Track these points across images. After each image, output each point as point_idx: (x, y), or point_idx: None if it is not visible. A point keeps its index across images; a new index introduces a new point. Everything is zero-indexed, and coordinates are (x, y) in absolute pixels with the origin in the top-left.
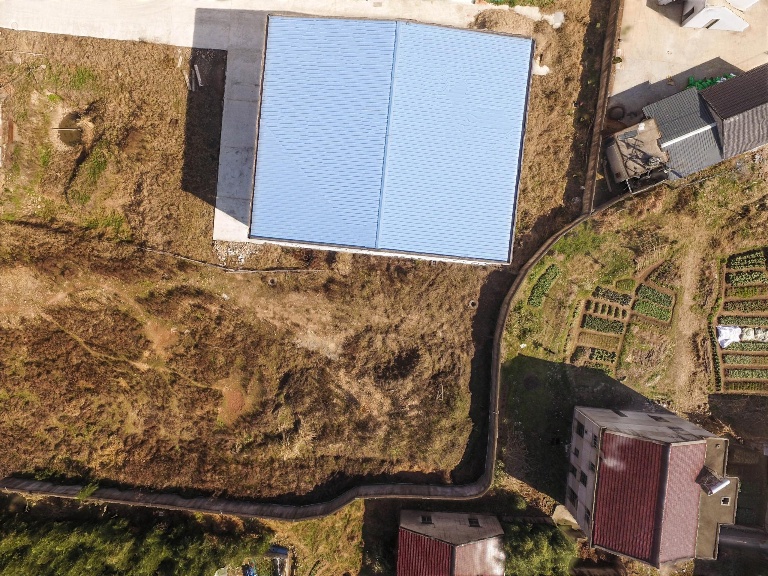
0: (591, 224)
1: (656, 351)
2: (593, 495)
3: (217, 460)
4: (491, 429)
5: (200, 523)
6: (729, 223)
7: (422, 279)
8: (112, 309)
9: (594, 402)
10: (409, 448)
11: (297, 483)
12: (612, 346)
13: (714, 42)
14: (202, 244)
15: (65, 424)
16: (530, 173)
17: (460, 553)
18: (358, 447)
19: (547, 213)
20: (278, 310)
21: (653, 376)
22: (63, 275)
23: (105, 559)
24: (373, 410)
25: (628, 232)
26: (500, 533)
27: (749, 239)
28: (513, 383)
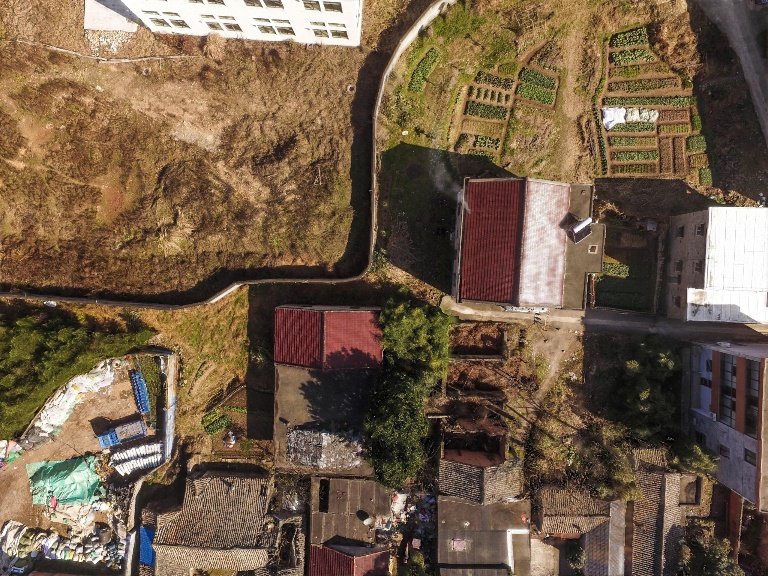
0: (469, 4)
1: (540, 136)
2: (459, 248)
3: (96, 256)
4: None
5: (82, 324)
6: None
7: (298, 63)
8: None
9: None
10: (289, 236)
11: (179, 280)
12: (496, 132)
13: None
14: (74, 35)
15: None
16: None
17: (330, 320)
18: (238, 238)
19: None
20: (153, 101)
21: (538, 161)
22: None
23: None
24: (250, 196)
25: (508, 12)
26: (377, 310)
27: (630, 14)
28: (396, 172)
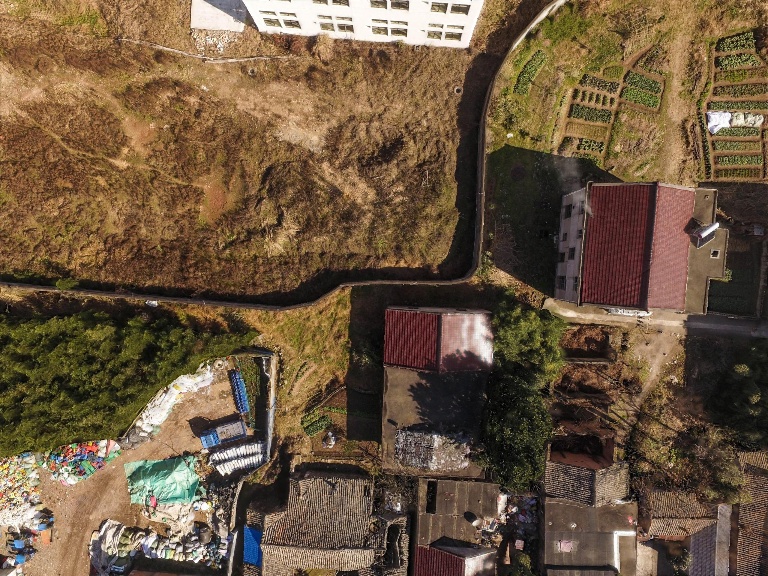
0: (577, 7)
1: (645, 139)
2: (580, 252)
3: (199, 256)
4: (478, 216)
5: (184, 324)
6: (718, 3)
7: (405, 65)
8: (89, 104)
9: None
10: (395, 238)
11: (282, 281)
12: (600, 136)
13: None
14: (179, 34)
15: (44, 225)
16: None
17: (446, 322)
18: (343, 240)
19: None
20: (259, 101)
21: (642, 165)
22: (38, 69)
23: (86, 350)
24: (357, 198)
25: (615, 15)
26: (488, 312)
27: (738, 19)
28: (500, 175)
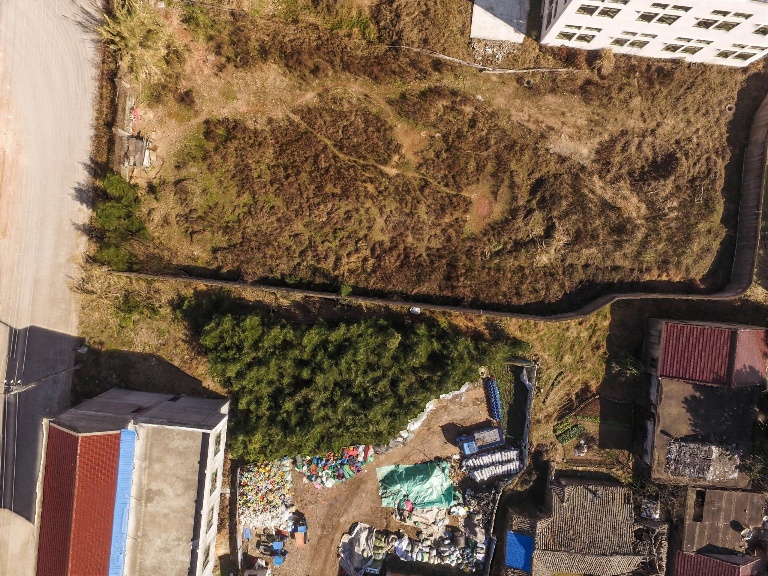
0: None
1: None
2: None
3: (468, 266)
4: (746, 233)
5: None
6: None
7: (681, 81)
8: (362, 110)
9: None
10: (664, 252)
11: (545, 291)
12: None
13: None
14: (458, 42)
15: (311, 230)
16: None
17: (739, 338)
18: (611, 253)
19: None
20: (533, 113)
21: None
22: (313, 73)
23: (366, 357)
24: (632, 212)
25: None
26: (764, 328)
27: None
28: None
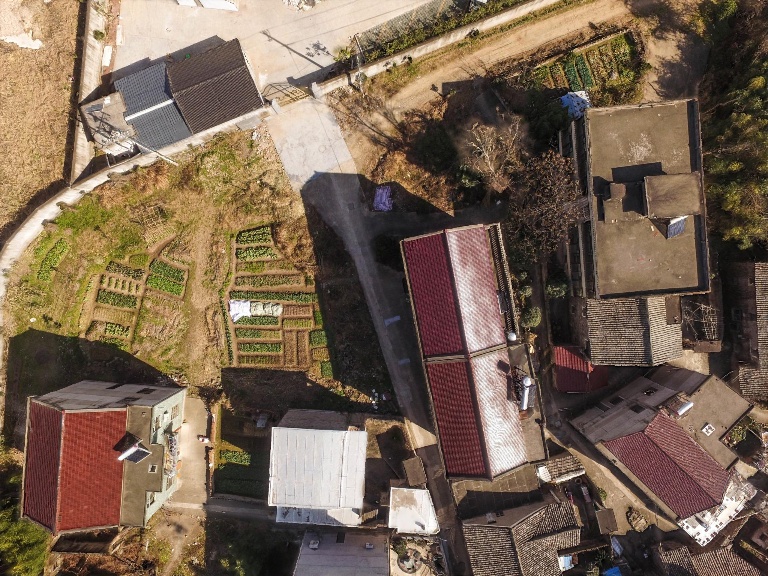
0: (97, 198)
1: (169, 325)
2: None
3: None
4: None
5: None
6: (234, 199)
7: None
8: None
9: (104, 376)
10: None
11: None
12: (126, 320)
13: (211, 21)
14: None
15: None
16: (29, 146)
17: None
18: None
19: (44, 186)
20: None
21: (166, 350)
22: None
23: None
24: None
25: (136, 207)
26: None
27: (252, 215)
28: (24, 357)
